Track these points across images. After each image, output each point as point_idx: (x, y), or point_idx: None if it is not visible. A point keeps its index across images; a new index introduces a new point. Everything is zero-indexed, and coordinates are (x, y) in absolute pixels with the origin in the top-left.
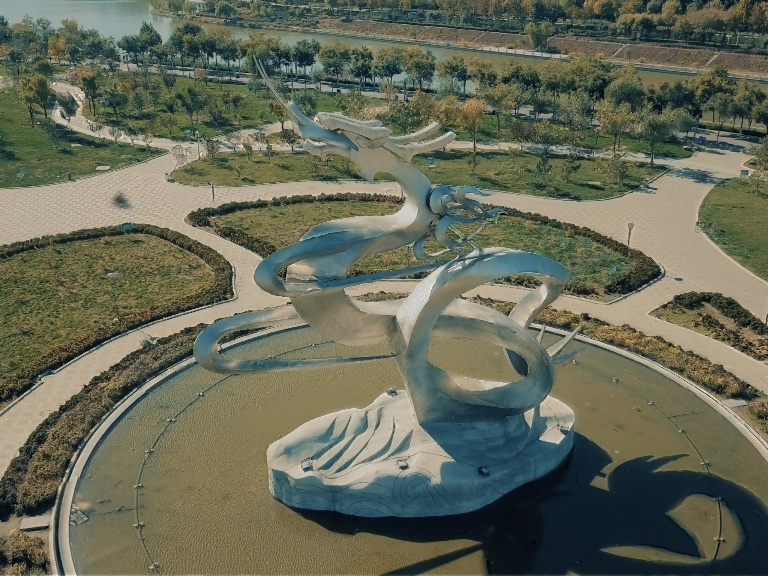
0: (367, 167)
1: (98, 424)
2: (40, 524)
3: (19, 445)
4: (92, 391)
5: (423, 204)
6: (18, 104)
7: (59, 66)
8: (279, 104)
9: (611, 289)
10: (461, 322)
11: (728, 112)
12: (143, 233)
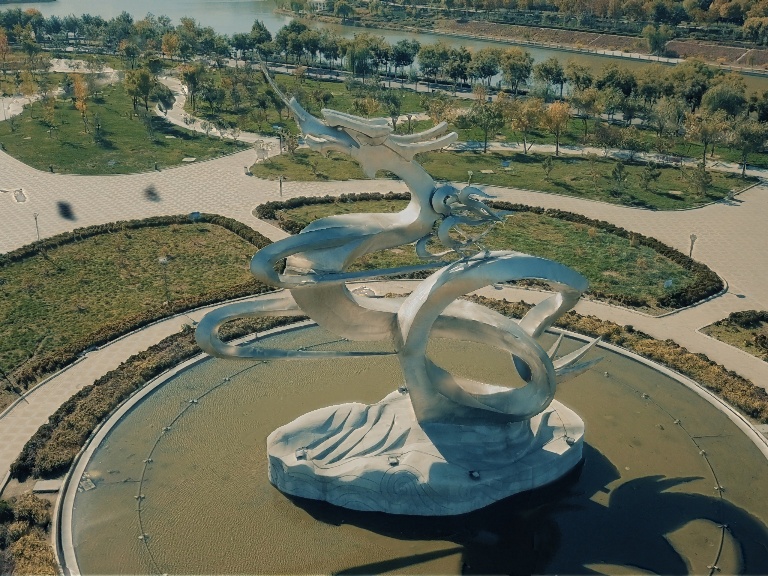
0: (368, 164)
1: (126, 400)
2: (51, 487)
3: (51, 413)
4: (126, 368)
5: (427, 203)
6: (127, 97)
7: (171, 61)
8: (364, 102)
9: (664, 302)
10: (465, 324)
11: None
12: (211, 223)
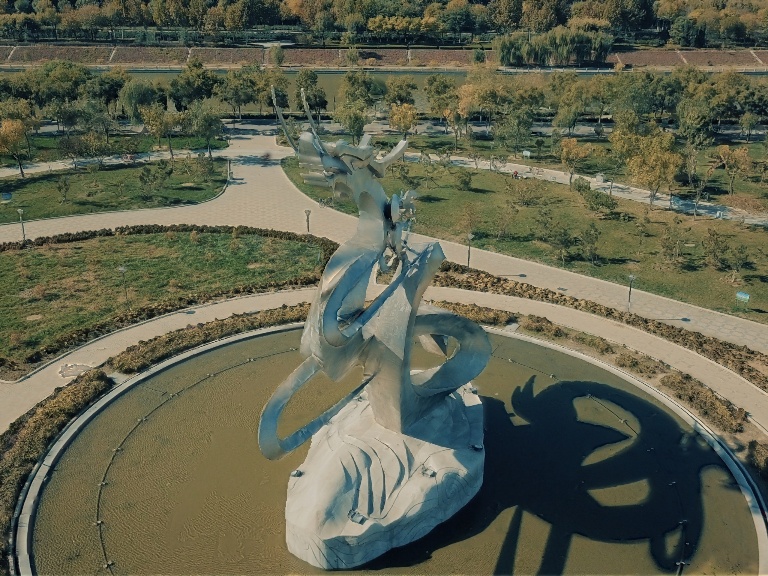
0: (356, 190)
1: None
2: None
3: None
4: None
5: None
6: None
7: None
8: None
9: None
10: None
11: (240, 100)
12: None
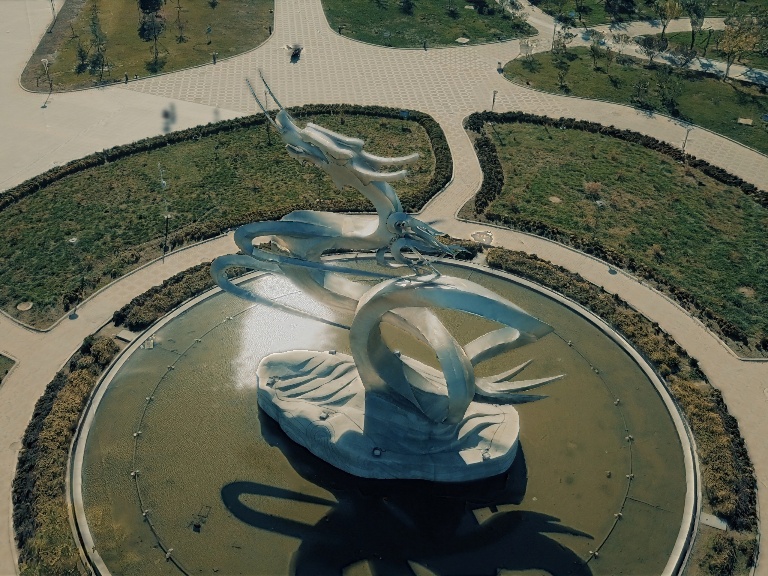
0: (336, 178)
1: None
2: (127, 338)
3: None
4: None
5: None
6: None
7: None
8: (664, 6)
9: (766, 345)
10: (414, 328)
11: None
12: (419, 123)
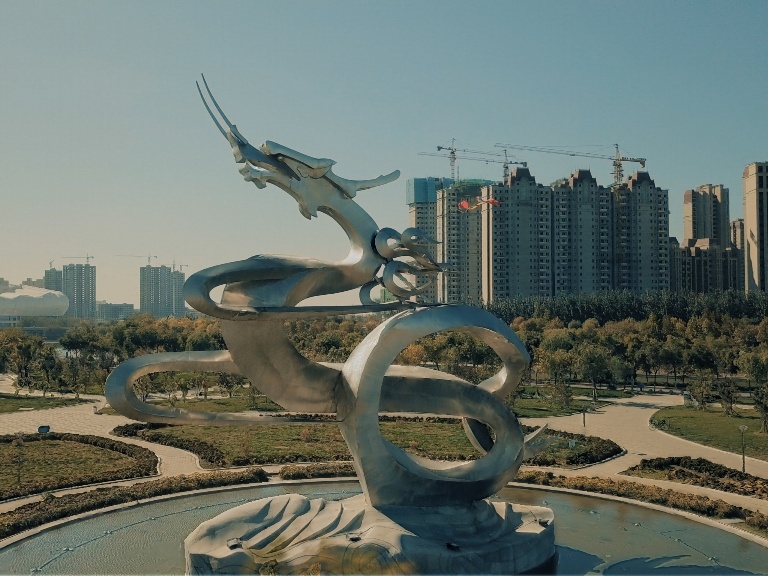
0: (309, 199)
1: None
2: None
3: None
4: None
5: (368, 248)
6: None
7: None
8: None
9: (573, 460)
10: (415, 386)
11: (660, 358)
12: (61, 440)
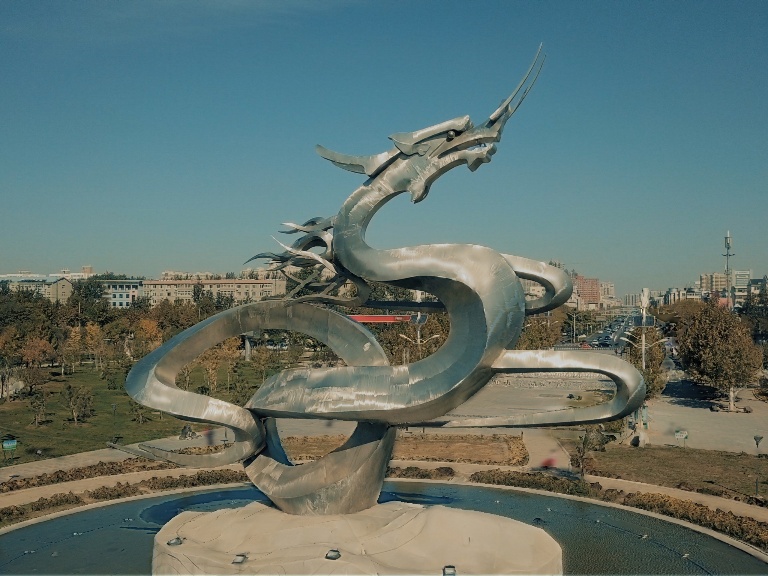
0: None
1: None
2: None
3: None
4: None
5: None
6: None
7: None
8: None
9: None
10: None
11: None
12: None
